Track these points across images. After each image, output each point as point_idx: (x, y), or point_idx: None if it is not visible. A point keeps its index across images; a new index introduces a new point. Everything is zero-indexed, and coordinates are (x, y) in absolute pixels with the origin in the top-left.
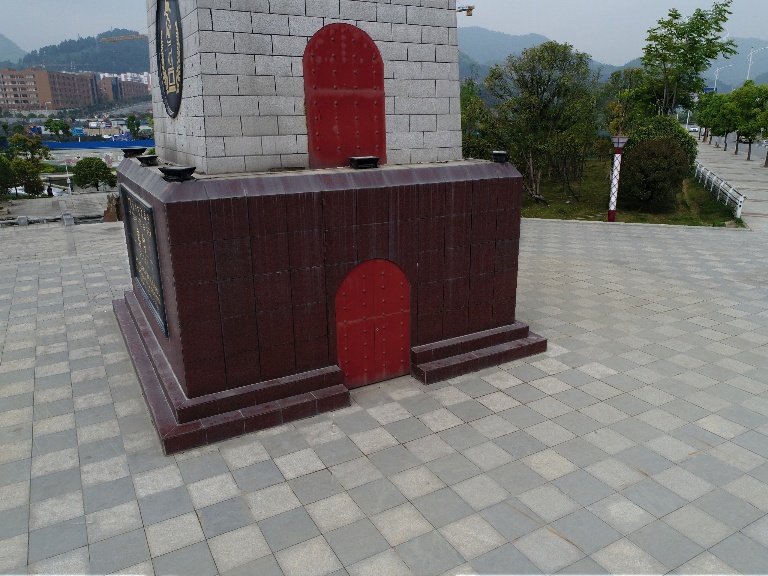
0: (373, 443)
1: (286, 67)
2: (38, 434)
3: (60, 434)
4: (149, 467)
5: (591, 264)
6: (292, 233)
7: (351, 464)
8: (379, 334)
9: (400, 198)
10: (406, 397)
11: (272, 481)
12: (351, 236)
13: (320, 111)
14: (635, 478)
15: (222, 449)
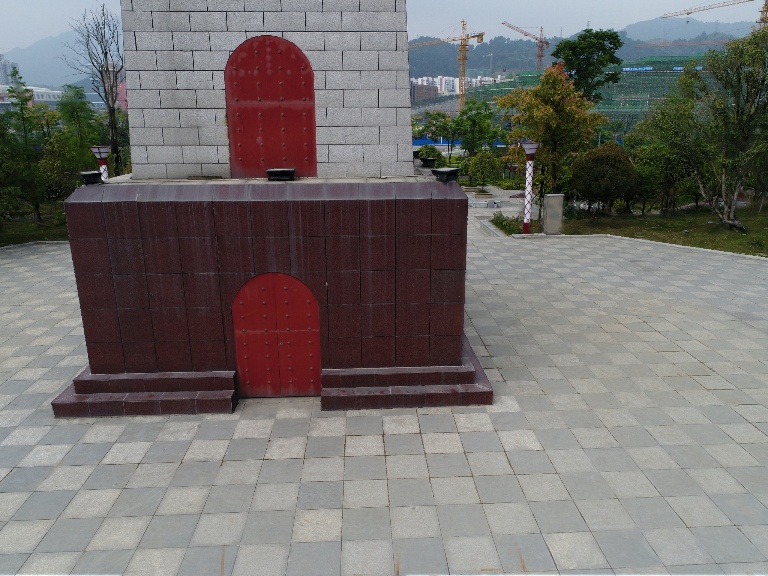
0: (202, 453)
1: (207, 81)
2: (13, 378)
3: (23, 382)
4: (35, 423)
5: (700, 313)
6: (183, 238)
7: (160, 466)
8: (283, 349)
9: (302, 213)
10: (288, 417)
11: (89, 461)
12: (247, 247)
13: (243, 123)
14: (380, 572)
15: (96, 424)
